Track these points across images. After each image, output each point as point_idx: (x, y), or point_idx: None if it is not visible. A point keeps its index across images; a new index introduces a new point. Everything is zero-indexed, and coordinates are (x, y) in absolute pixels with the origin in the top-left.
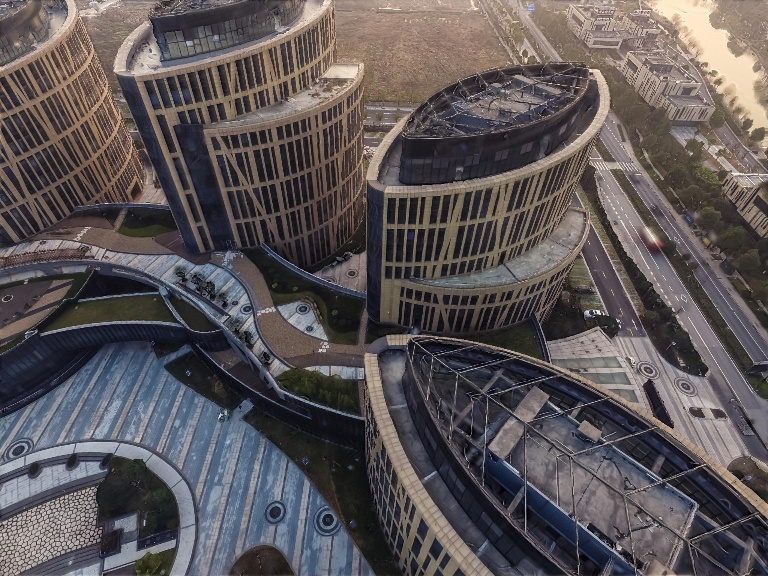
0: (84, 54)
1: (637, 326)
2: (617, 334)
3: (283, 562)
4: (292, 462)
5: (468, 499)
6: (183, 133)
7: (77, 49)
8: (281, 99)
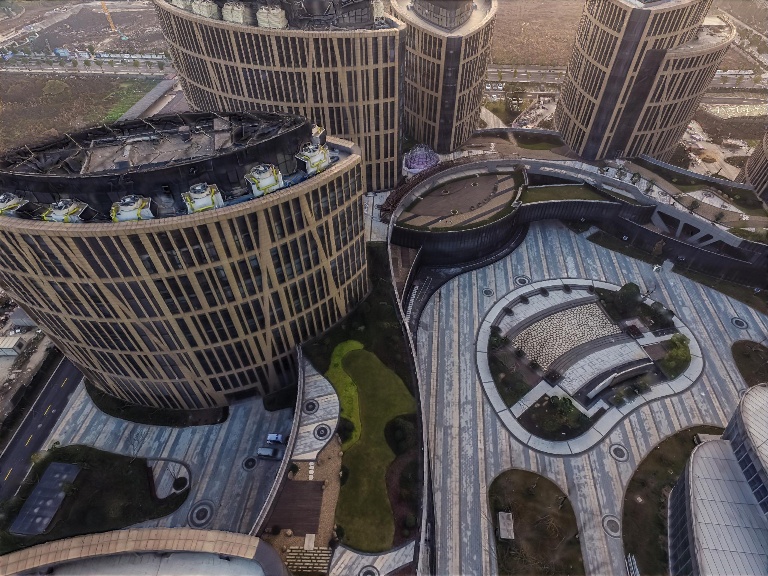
0: None
1: None
2: None
3: (767, 349)
4: (730, 297)
5: None
6: (650, 56)
7: None
8: (694, 36)
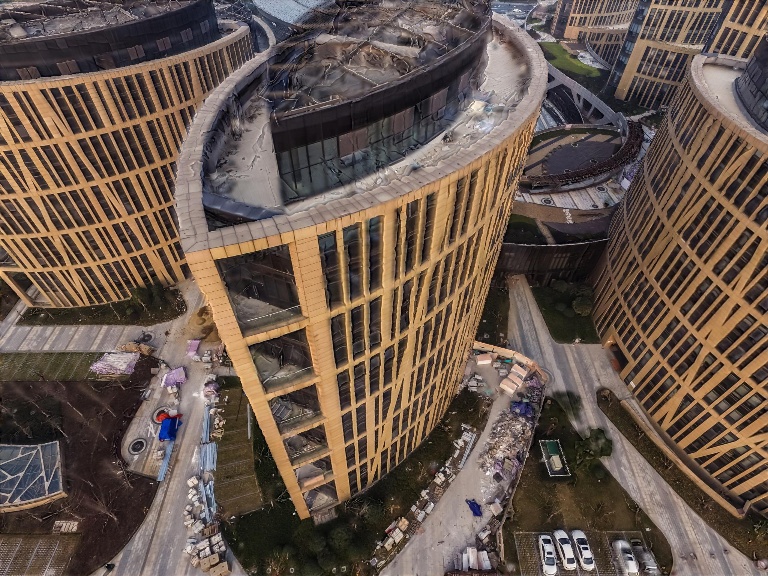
0: (767, 217)
1: None
2: None
3: None
4: None
5: None
6: None
7: (764, 192)
8: None
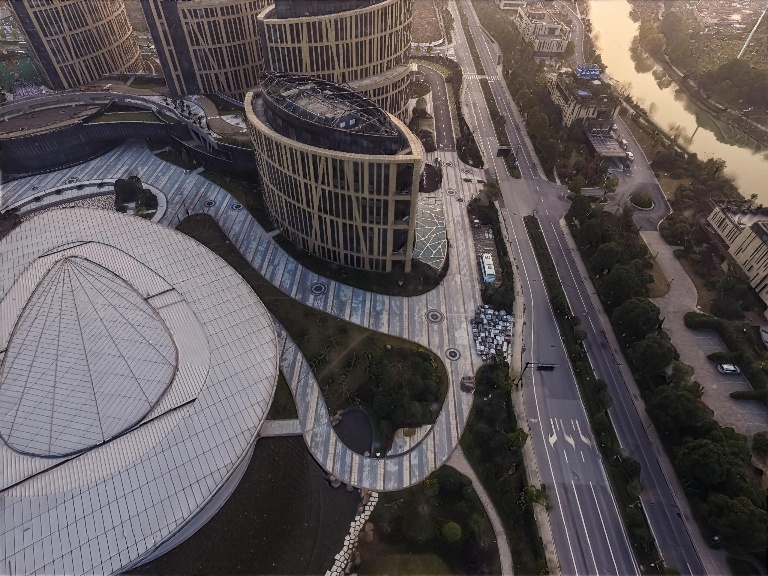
0: None
1: (452, 147)
2: (437, 150)
3: (211, 218)
4: (223, 189)
5: (274, 119)
6: (166, 6)
7: None
8: None
